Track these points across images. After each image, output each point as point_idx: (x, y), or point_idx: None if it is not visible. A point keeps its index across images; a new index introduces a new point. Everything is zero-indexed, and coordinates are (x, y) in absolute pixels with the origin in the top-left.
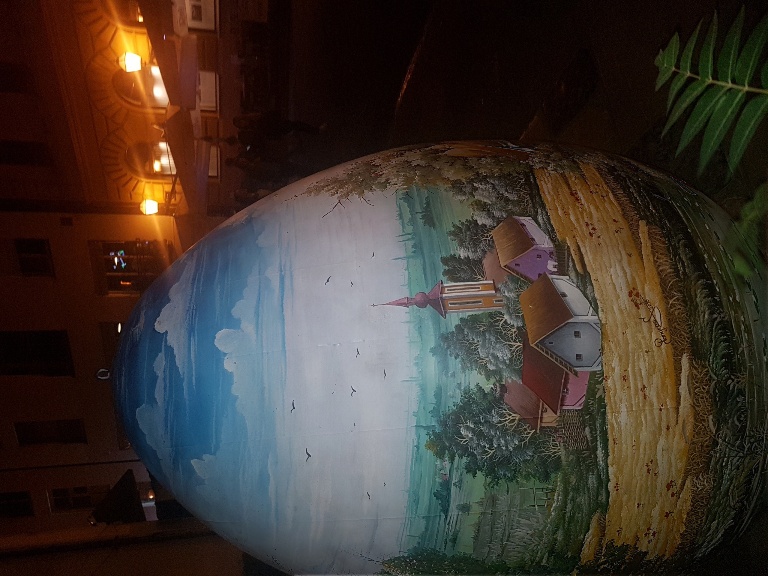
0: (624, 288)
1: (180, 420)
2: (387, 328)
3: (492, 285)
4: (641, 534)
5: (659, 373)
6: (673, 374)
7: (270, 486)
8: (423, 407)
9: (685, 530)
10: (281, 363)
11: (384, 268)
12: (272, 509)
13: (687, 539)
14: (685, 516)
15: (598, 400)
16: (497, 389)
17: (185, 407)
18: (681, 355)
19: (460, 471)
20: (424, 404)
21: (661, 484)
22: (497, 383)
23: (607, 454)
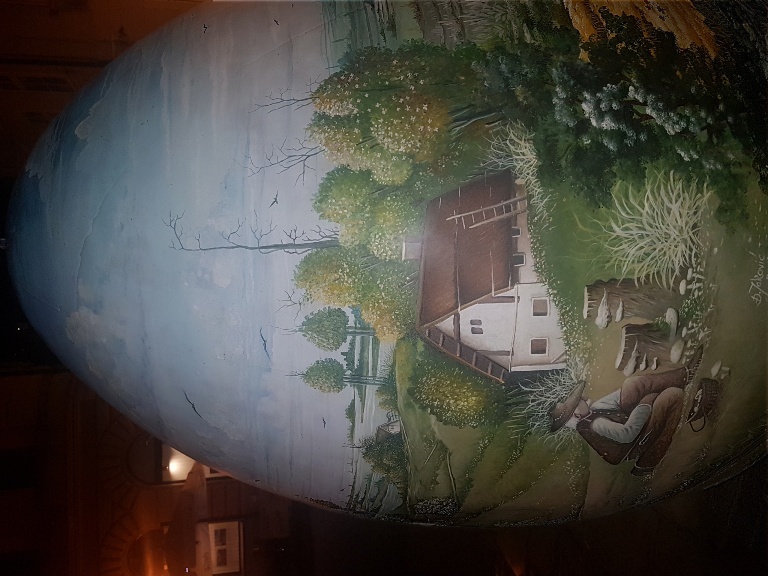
0: None
1: None
2: None
3: None
4: (641, 6)
5: None
6: None
7: (162, 78)
8: None
9: (706, 19)
10: None
11: None
12: (164, 103)
13: (722, 34)
14: (689, 2)
15: None
16: None
17: None
18: None
19: None
20: None
21: None
22: None
23: None
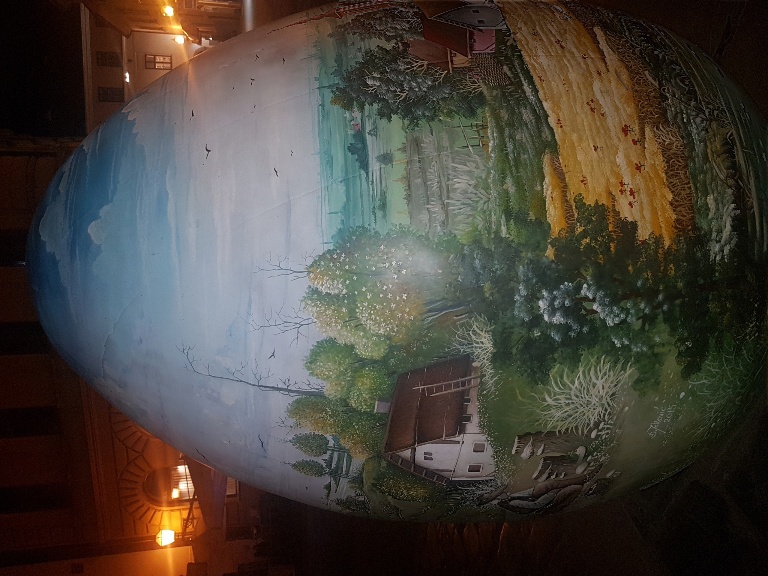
0: None
1: (80, 191)
2: (285, 36)
3: (386, 0)
4: (615, 190)
5: (571, 34)
6: (588, 36)
7: (169, 206)
8: (324, 72)
9: (673, 198)
10: (182, 90)
11: (285, 19)
12: (172, 238)
13: (683, 215)
14: (664, 175)
15: (510, 47)
16: (399, 46)
17: (86, 173)
18: (592, 27)
19: (373, 118)
20: (325, 69)
21: (614, 127)
22: (398, 42)
23: (536, 90)
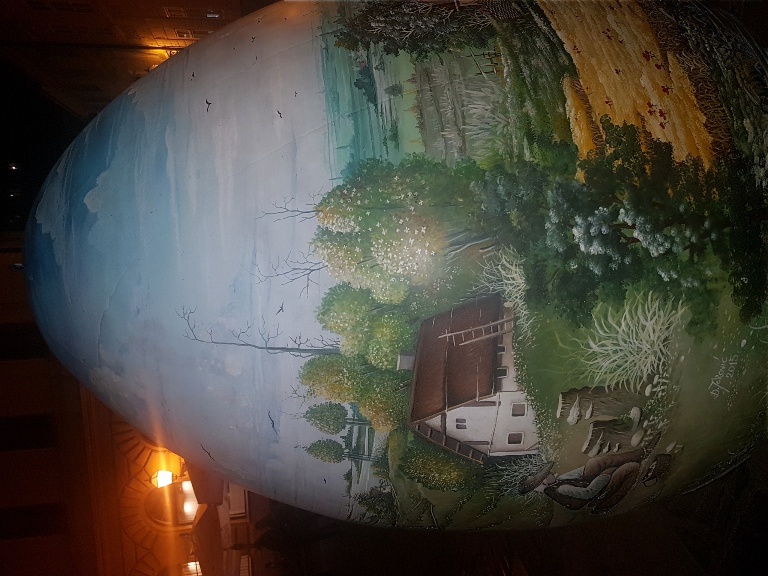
0: None
1: (78, 166)
2: None
3: None
4: (643, 111)
5: None
6: None
7: (168, 162)
8: (327, 22)
9: (707, 120)
10: (183, 60)
11: None
12: (171, 193)
13: (720, 138)
14: (694, 98)
15: None
16: None
17: (84, 148)
18: None
19: (379, 55)
20: (328, 20)
21: (634, 52)
22: None
23: (548, 21)
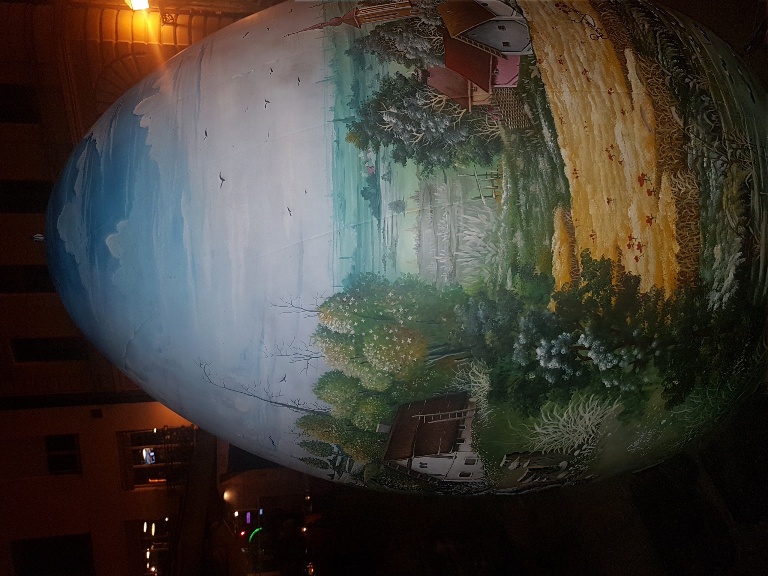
0: (549, 2)
1: (96, 199)
2: (301, 46)
3: (408, 3)
4: (622, 244)
5: (600, 61)
6: (617, 63)
7: (184, 233)
8: (340, 101)
9: (680, 250)
10: (195, 101)
11: (300, 14)
12: (188, 265)
13: (687, 267)
14: (674, 227)
15: (534, 79)
16: (419, 74)
17: (101, 181)
18: (623, 49)
19: (387, 161)
20: (341, 98)
21: (630, 176)
22: (418, 69)
23: (555, 134)
